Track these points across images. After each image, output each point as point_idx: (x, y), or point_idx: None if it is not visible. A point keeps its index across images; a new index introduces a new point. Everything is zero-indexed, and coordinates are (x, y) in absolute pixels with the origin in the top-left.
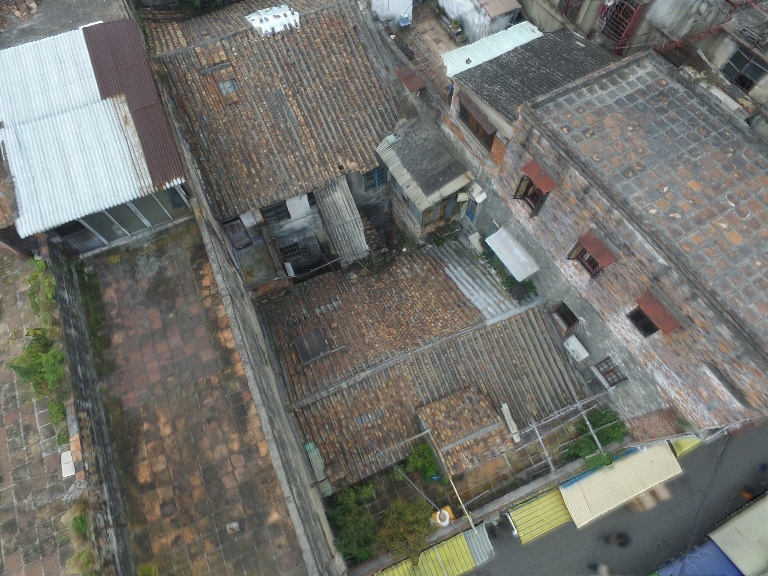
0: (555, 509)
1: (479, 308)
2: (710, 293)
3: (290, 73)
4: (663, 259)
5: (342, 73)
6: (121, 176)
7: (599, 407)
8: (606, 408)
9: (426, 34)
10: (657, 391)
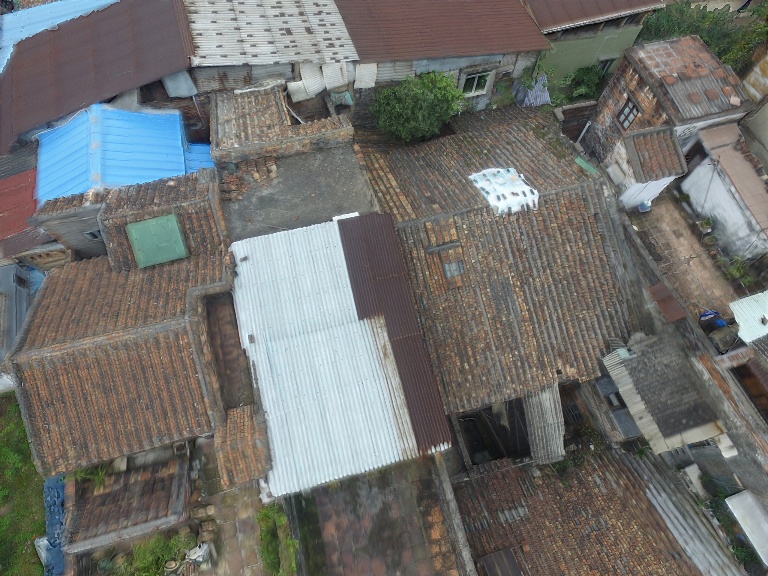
0: None
1: (699, 567)
2: None
3: (521, 260)
4: None
5: (575, 265)
6: (382, 429)
7: None
8: None
9: (664, 223)
10: None
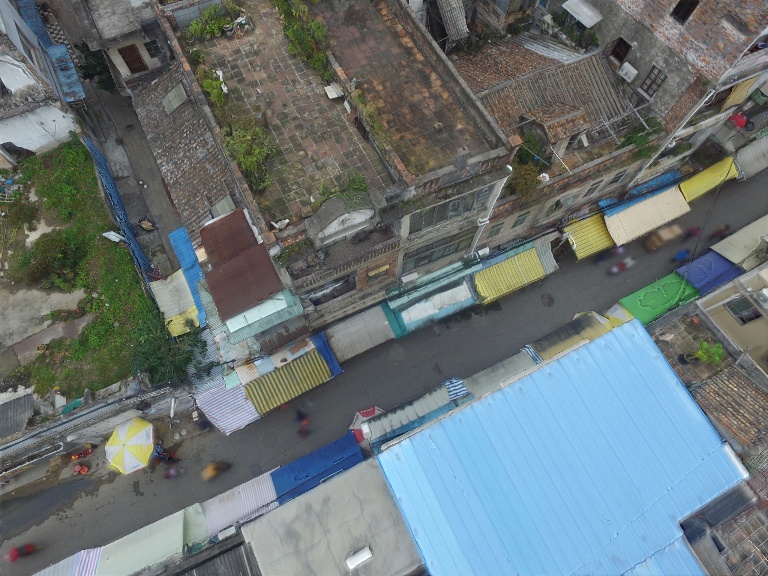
0: (600, 238)
1: (556, 59)
2: None
3: None
4: None
5: None
6: None
7: None
8: None
9: None
10: (688, 71)
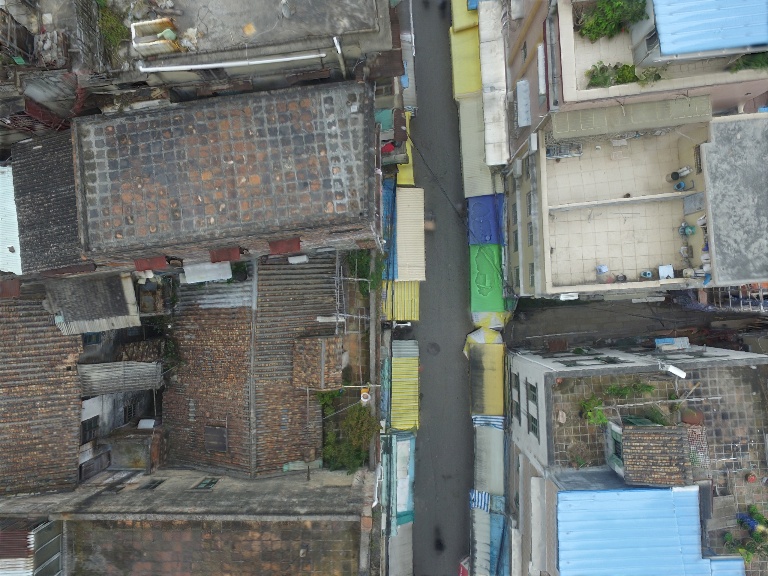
0: (409, 288)
1: (241, 306)
2: (281, 229)
3: None
4: None
5: None
6: None
7: None
8: (349, 253)
9: None
10: None
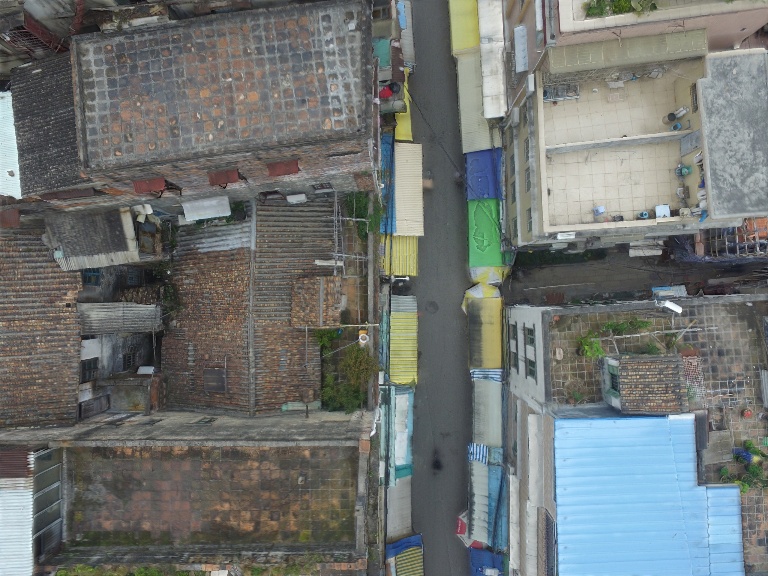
0: (407, 243)
1: (240, 247)
2: (280, 145)
3: None
4: (247, 153)
5: None
6: (6, 501)
7: (346, 198)
8: (347, 196)
9: None
10: (341, 175)
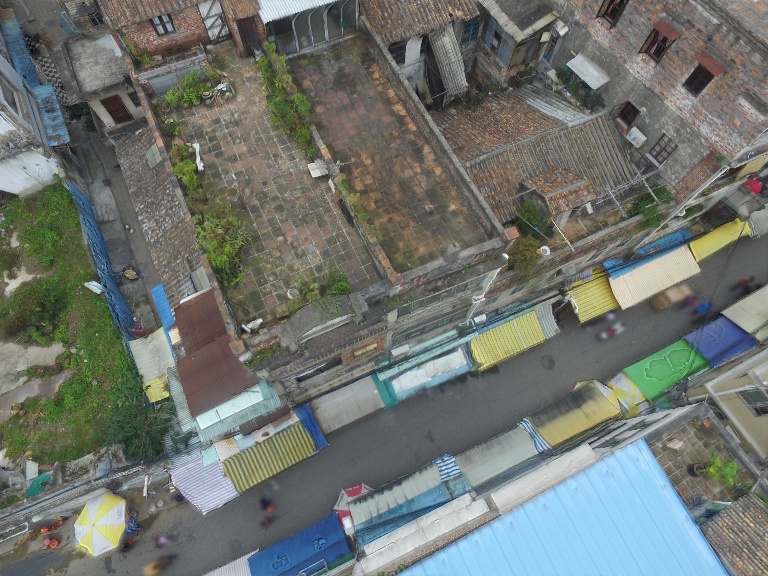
0: (605, 299)
1: (560, 119)
2: (749, 32)
3: None
4: (717, 20)
5: None
6: None
7: None
8: None
9: None
10: (701, 143)
